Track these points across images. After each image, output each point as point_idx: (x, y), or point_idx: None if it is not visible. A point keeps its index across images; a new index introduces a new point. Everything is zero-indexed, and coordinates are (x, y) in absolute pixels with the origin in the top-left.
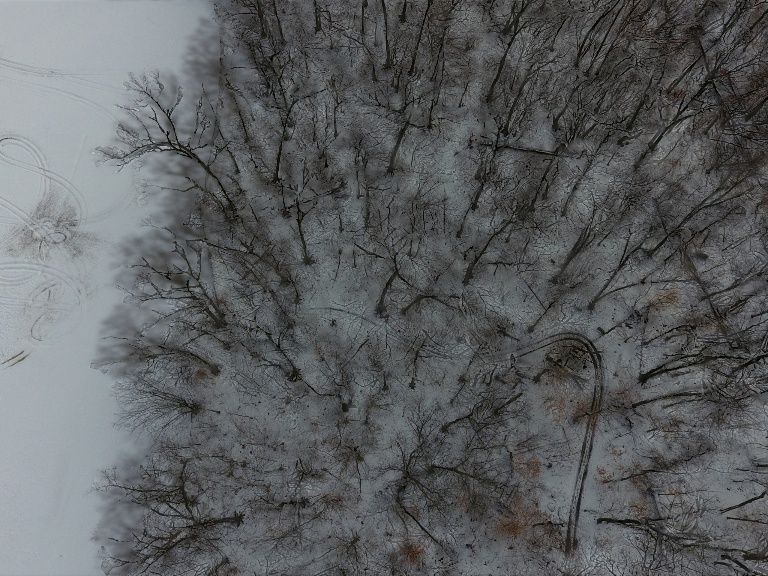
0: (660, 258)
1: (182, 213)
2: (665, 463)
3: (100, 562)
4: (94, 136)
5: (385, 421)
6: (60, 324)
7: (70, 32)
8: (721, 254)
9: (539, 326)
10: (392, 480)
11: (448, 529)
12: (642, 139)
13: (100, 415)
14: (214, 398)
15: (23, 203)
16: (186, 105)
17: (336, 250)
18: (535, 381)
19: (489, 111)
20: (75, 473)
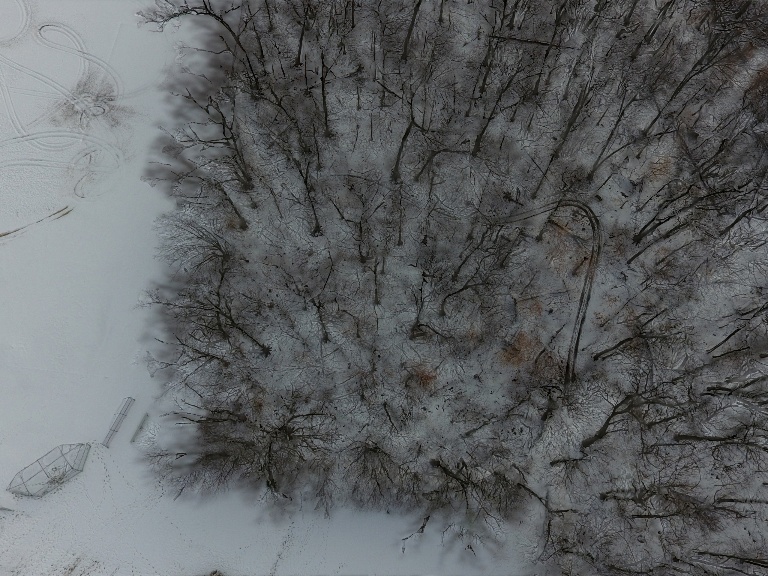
0: (654, 136)
1: (211, 90)
2: (657, 310)
3: (142, 382)
4: (129, 24)
5: (400, 270)
6: (101, 184)
7: None
8: None
9: (542, 193)
10: (406, 321)
11: (458, 361)
12: (639, 33)
13: (139, 261)
14: (243, 248)
15: (64, 81)
16: None
17: (354, 125)
18: (538, 240)
19: None
20: (117, 309)
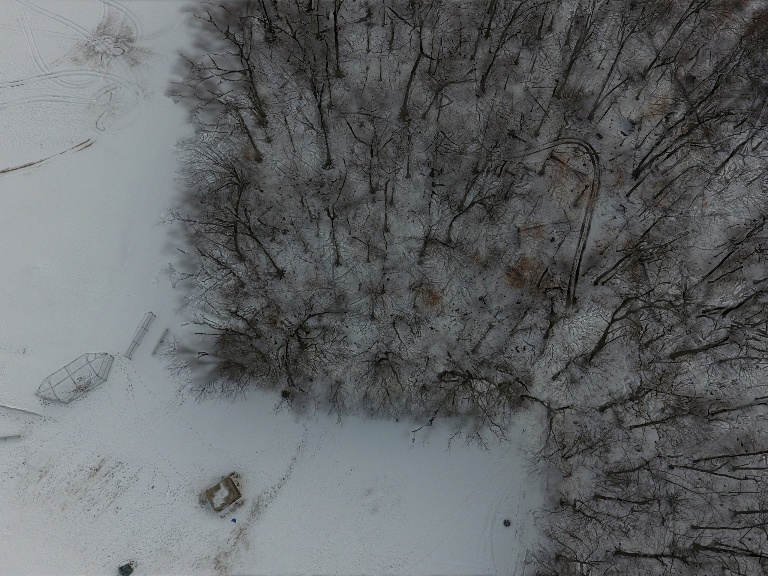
0: (653, 79)
1: None
2: (654, 240)
3: (162, 300)
4: None
5: (408, 200)
6: (121, 119)
7: None
8: None
9: (544, 131)
10: (414, 247)
11: (463, 283)
12: None
13: (159, 189)
14: (258, 178)
15: (85, 23)
16: None
17: (364, 67)
18: (540, 174)
19: None
20: (138, 233)
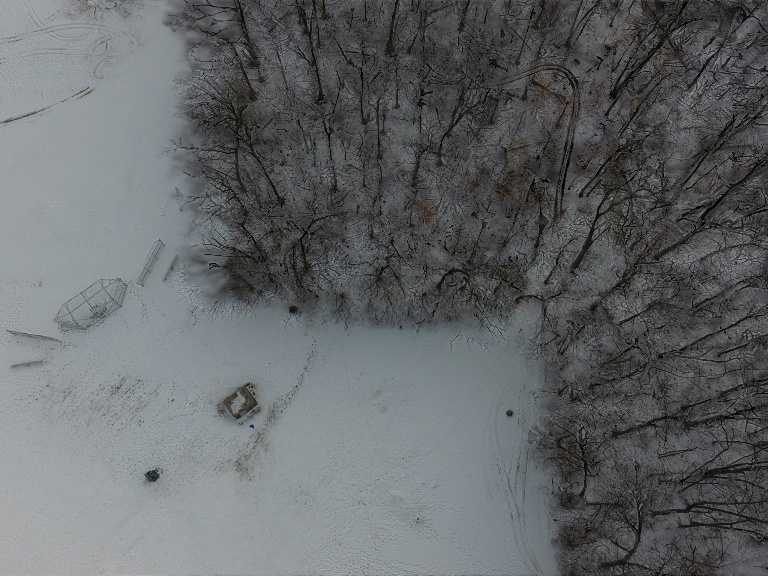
0: (625, 7)
1: None
2: None
3: (170, 230)
4: None
5: (399, 128)
6: (118, 67)
7: None
8: (677, 3)
9: (524, 59)
10: (407, 171)
11: (456, 201)
12: None
13: (159, 129)
14: (254, 115)
15: None
16: None
17: (349, 8)
18: (523, 99)
19: None
20: (142, 171)
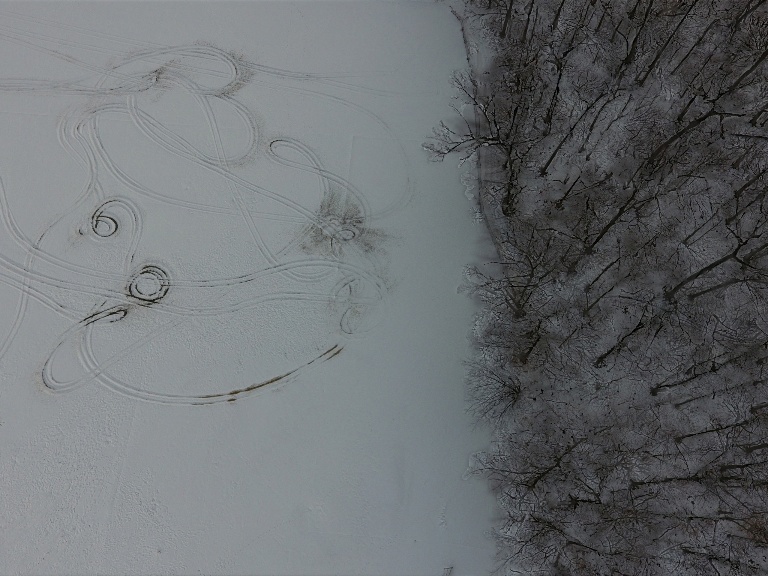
0: None
1: (462, 208)
2: None
3: (455, 546)
4: (361, 136)
5: (697, 404)
6: (367, 318)
7: (317, 37)
8: None
9: None
10: None
11: None
12: None
13: (424, 404)
14: (530, 385)
15: (307, 202)
16: (444, 104)
17: (614, 240)
18: None
19: (733, 102)
20: (412, 461)
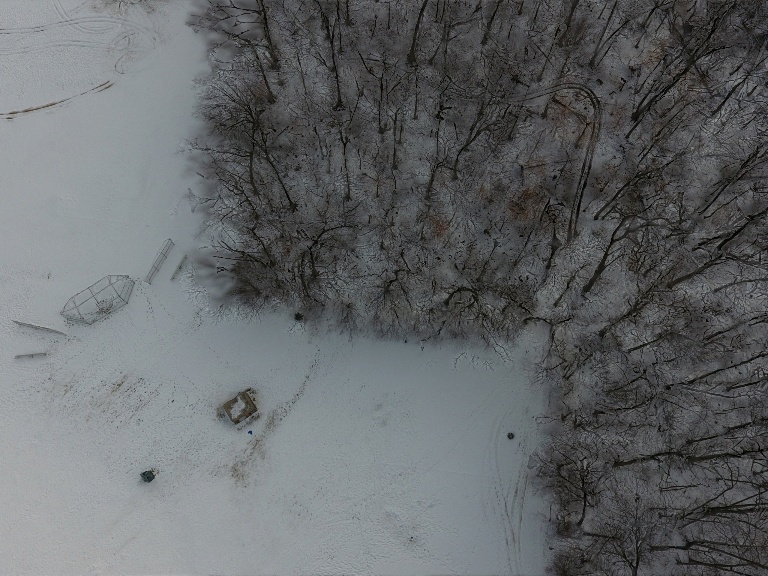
0: (652, 29)
1: None
2: None
3: (180, 229)
4: None
5: None
6: (139, 62)
7: None
8: None
9: (547, 76)
10: (422, 183)
11: (469, 217)
12: None
13: (176, 127)
14: (271, 118)
15: None
16: None
17: (372, 15)
18: (543, 117)
19: None
20: (157, 168)
